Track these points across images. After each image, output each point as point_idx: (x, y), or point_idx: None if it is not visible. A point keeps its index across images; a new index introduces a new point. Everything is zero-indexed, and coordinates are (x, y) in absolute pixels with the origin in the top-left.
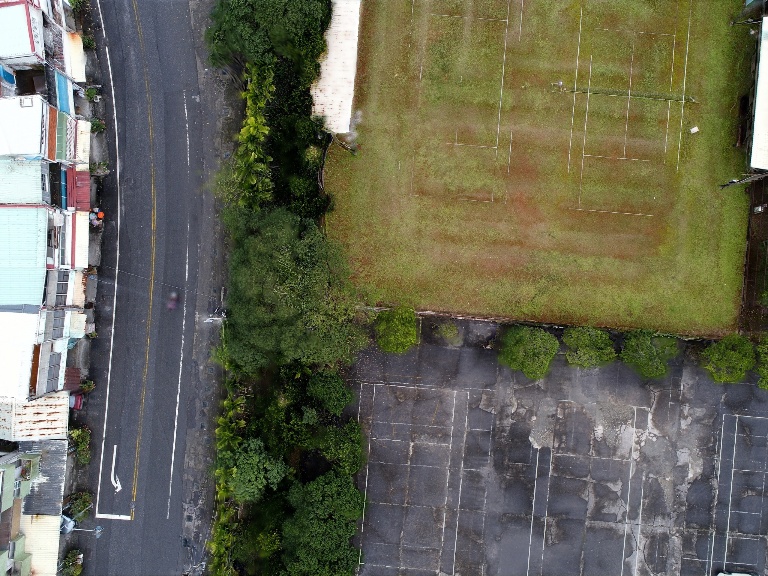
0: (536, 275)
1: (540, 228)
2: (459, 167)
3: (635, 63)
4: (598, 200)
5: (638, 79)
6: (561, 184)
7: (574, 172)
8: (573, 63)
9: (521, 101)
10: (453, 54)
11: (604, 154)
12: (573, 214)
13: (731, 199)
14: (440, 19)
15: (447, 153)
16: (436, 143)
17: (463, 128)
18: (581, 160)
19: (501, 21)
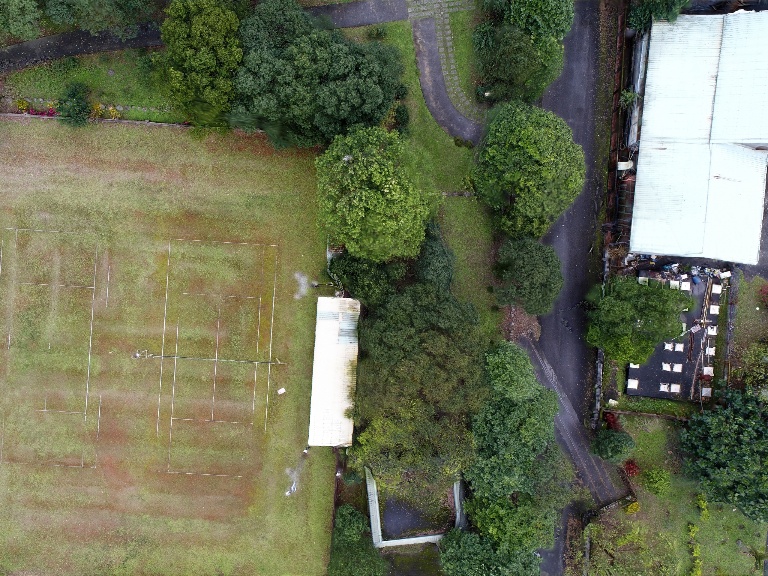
0: (127, 538)
1: (130, 492)
2: (49, 433)
3: (221, 326)
4: (187, 462)
5: (225, 342)
6: (150, 448)
7: (163, 435)
8: (160, 328)
9: (109, 367)
10: (41, 322)
11: (192, 417)
12: (163, 477)
13: (319, 458)
14: (27, 287)
15: (37, 420)
16: (25, 410)
17: (52, 395)
18: (170, 423)
19: (88, 288)
